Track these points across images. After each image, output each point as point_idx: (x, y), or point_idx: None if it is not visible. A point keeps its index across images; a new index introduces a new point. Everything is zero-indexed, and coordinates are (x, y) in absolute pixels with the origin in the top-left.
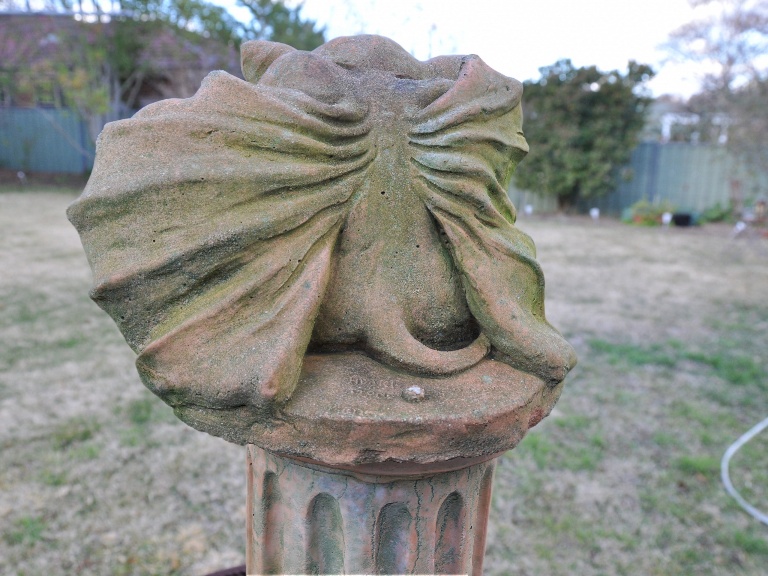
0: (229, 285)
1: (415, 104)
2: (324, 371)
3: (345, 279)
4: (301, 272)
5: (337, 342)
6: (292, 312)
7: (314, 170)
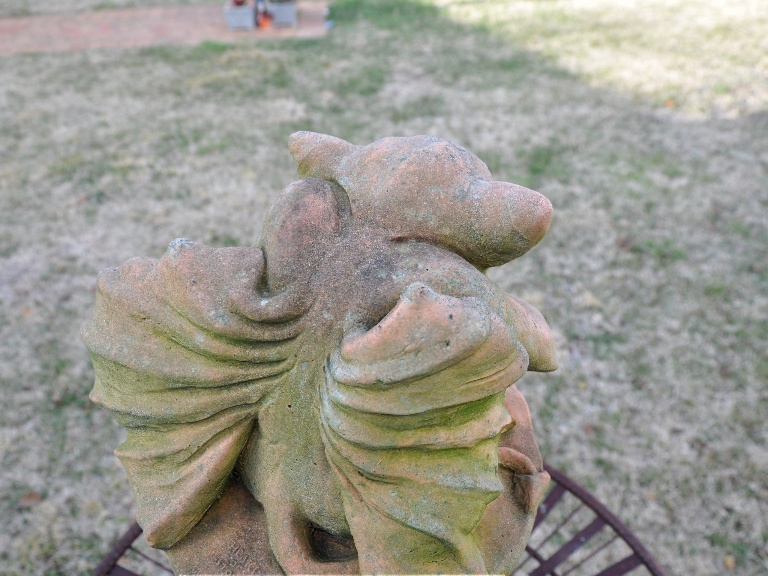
0: (155, 440)
1: (364, 308)
2: (227, 521)
3: (258, 457)
4: (202, 454)
5: None
6: (188, 483)
7: (219, 376)
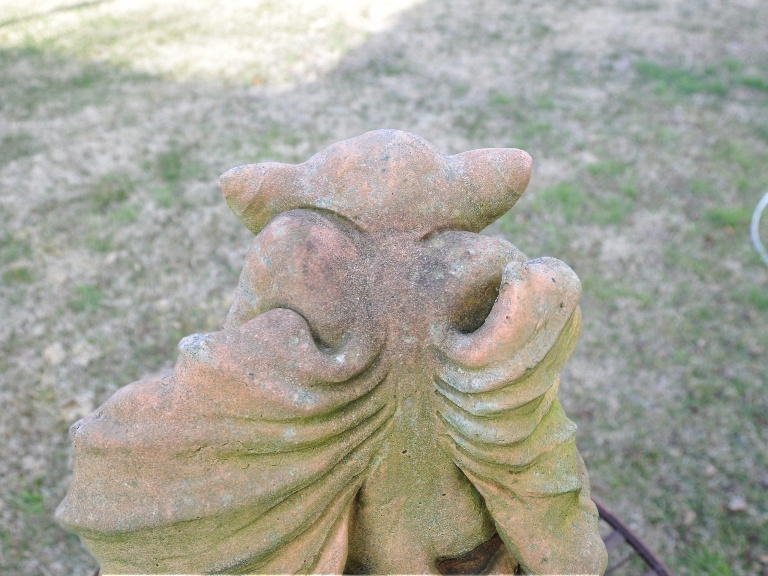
0: None
1: (443, 315)
2: None
3: (365, 530)
4: (317, 562)
5: (359, 574)
6: None
7: (324, 463)
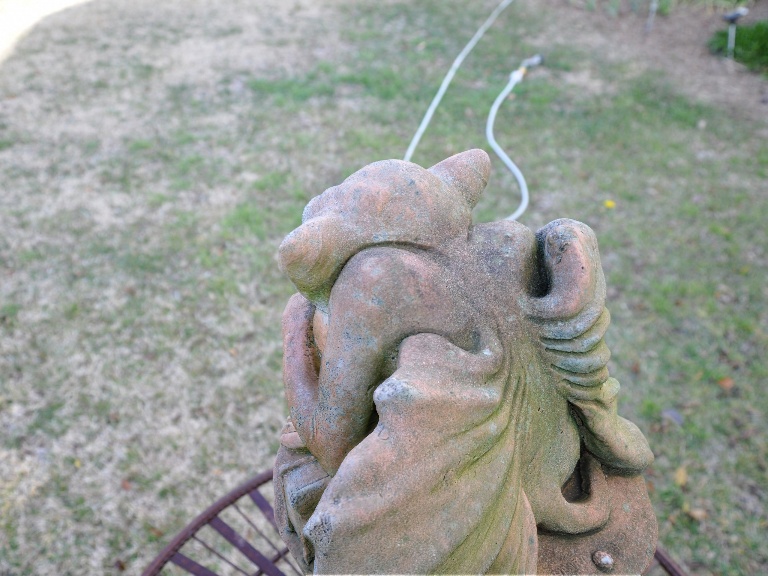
0: None
1: (520, 290)
2: None
3: None
4: None
5: None
6: (529, 572)
7: None
